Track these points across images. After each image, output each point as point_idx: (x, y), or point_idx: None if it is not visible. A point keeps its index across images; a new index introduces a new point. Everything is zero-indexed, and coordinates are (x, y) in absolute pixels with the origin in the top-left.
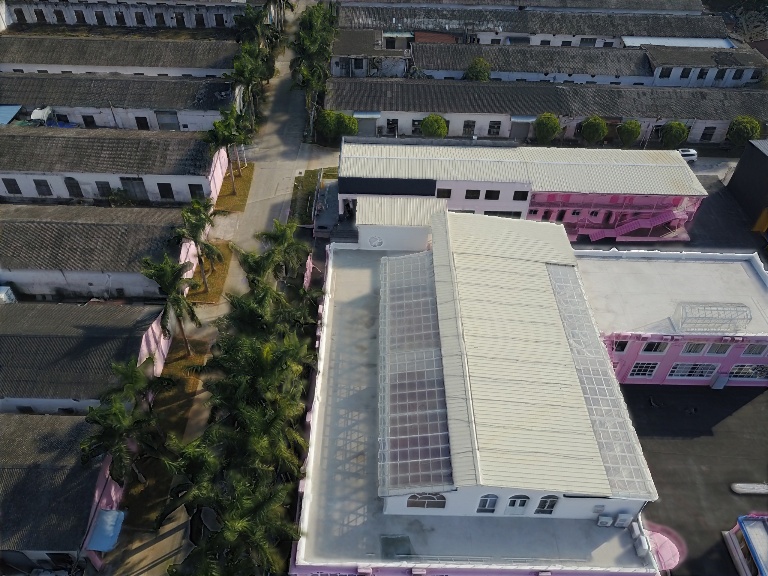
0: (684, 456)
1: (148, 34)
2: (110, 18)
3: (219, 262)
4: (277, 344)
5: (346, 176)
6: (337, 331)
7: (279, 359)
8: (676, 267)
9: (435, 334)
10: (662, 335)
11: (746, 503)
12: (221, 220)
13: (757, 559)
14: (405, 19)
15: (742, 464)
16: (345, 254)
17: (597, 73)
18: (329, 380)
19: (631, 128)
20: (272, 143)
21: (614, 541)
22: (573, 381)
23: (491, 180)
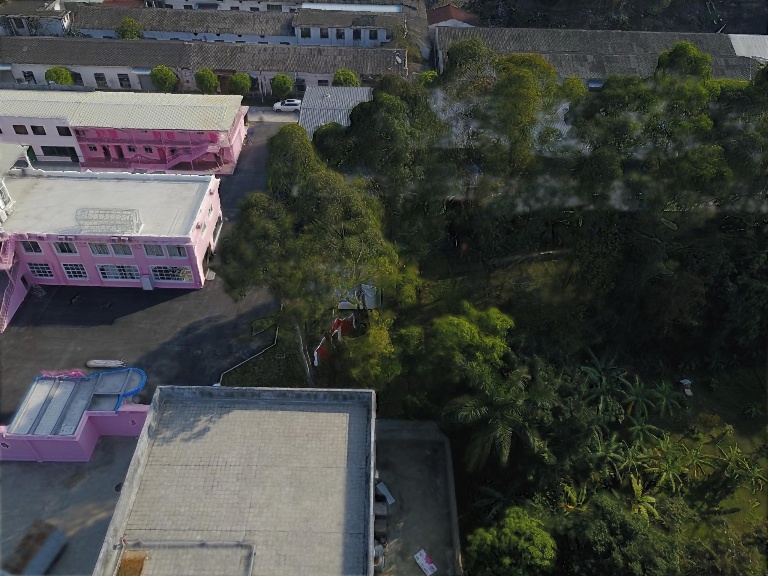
0: (70, 340)
1: None
2: None
3: None
4: None
5: None
6: None
7: None
8: (138, 186)
9: None
10: (57, 235)
11: (91, 374)
12: None
13: (21, 407)
14: None
15: (116, 346)
16: None
17: (242, 33)
18: None
19: (236, 79)
20: None
21: None
22: None
23: None
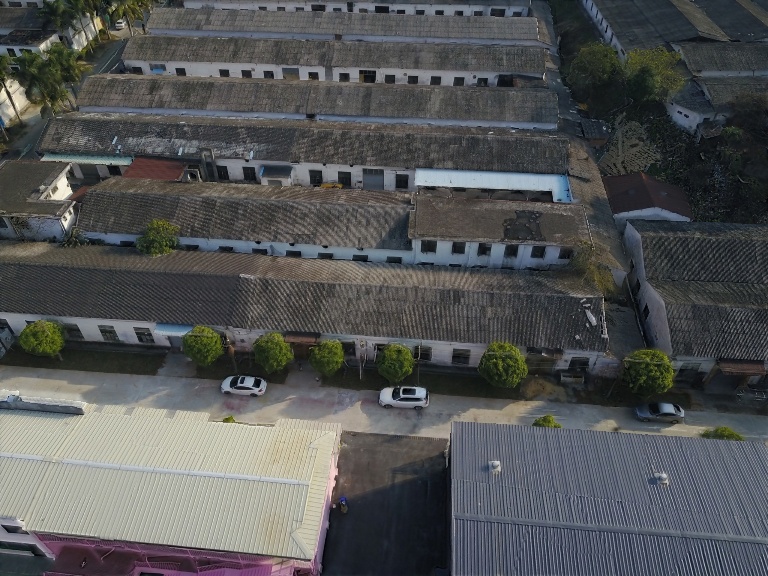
0: None
1: None
2: None
3: None
4: None
5: None
6: None
7: None
8: None
9: None
10: None
11: None
12: None
13: None
14: (130, 138)
15: None
16: None
17: (329, 243)
18: None
19: (320, 357)
20: None
21: None
22: None
23: None
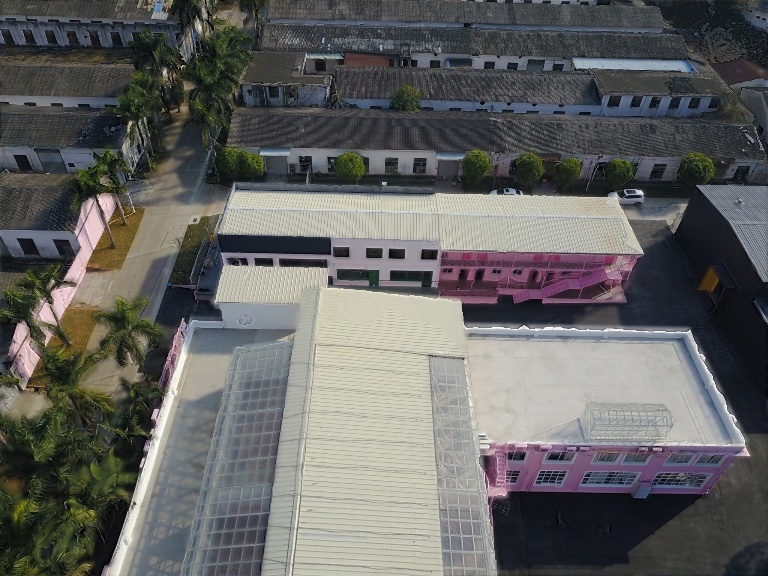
0: None
1: (59, 54)
2: (18, 37)
3: (64, 342)
4: (75, 475)
5: (228, 232)
6: (173, 442)
7: (33, 523)
8: (596, 349)
9: (271, 462)
10: (565, 445)
11: None
12: (92, 280)
13: None
14: (336, 39)
15: None
16: (207, 335)
17: (538, 102)
18: (148, 513)
19: (569, 167)
20: (170, 183)
21: None
22: (432, 530)
23: (395, 237)
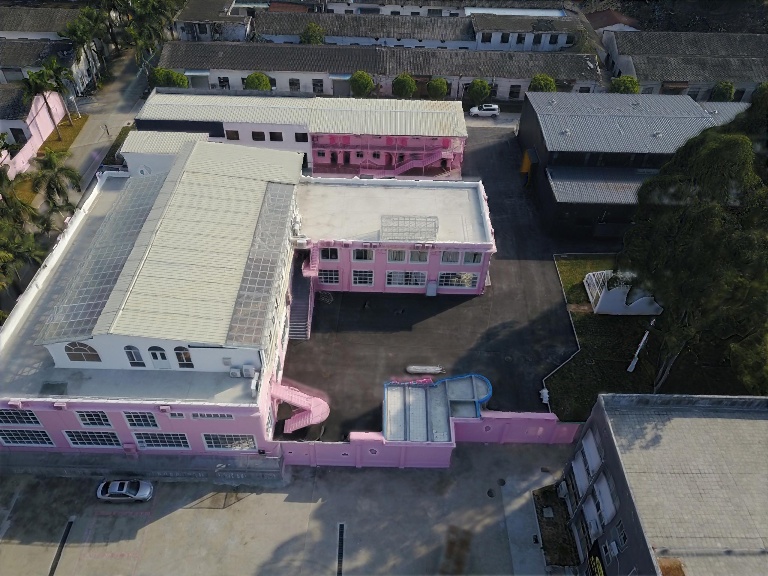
0: (378, 346)
1: (31, 6)
2: None
3: (11, 189)
4: None
5: (145, 119)
6: (80, 238)
7: None
8: (408, 192)
9: (138, 231)
10: (362, 242)
11: None
12: None
13: (385, 413)
14: None
15: (426, 352)
16: (116, 181)
17: (423, 38)
18: (55, 274)
19: (436, 84)
20: (112, 99)
21: (239, 387)
22: (239, 266)
23: None
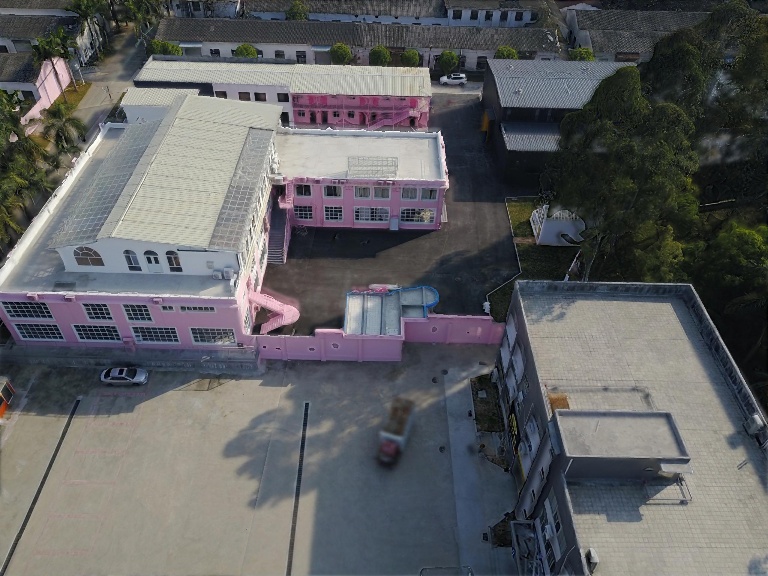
0: (345, 269)
1: None
2: None
3: None
4: None
5: None
6: (85, 175)
7: None
8: (375, 141)
9: (136, 164)
10: (331, 179)
11: None
12: None
13: (346, 314)
14: None
15: (386, 274)
16: (117, 131)
17: (399, 15)
18: (64, 202)
19: (408, 55)
20: (113, 69)
21: (220, 286)
22: (222, 191)
23: None
